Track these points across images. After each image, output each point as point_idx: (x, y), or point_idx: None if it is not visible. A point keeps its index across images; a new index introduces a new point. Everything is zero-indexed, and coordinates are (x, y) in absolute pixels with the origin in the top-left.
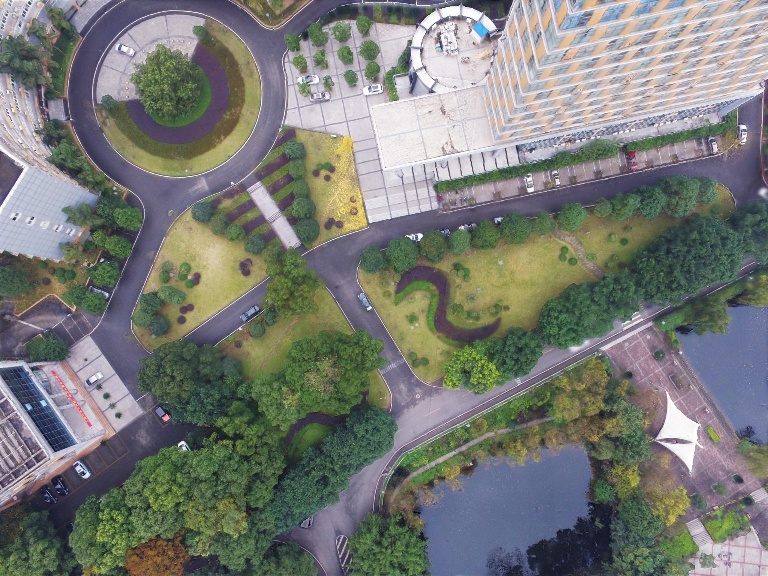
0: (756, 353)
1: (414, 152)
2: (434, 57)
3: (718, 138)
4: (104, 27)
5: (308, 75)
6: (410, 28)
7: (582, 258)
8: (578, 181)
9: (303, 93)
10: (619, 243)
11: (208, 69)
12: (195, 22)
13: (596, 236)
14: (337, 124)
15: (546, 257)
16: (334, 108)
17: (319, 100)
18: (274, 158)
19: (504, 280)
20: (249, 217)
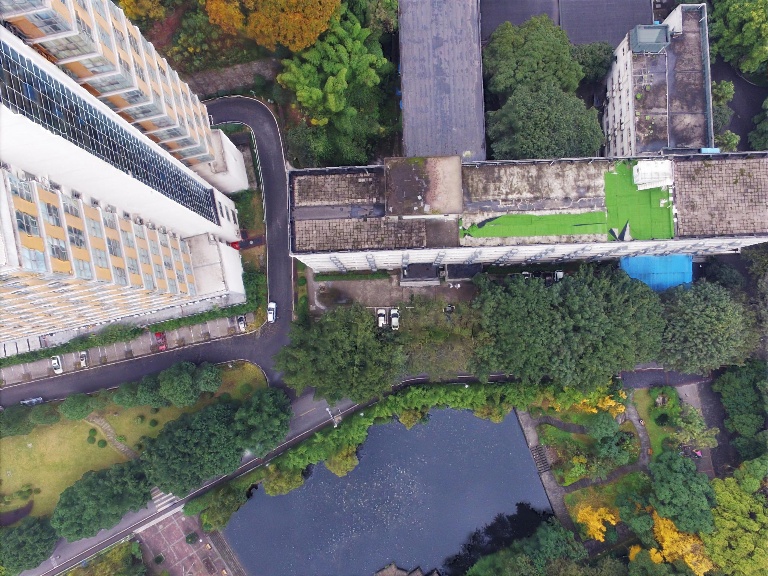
0: (298, 533)
1: None
2: None
3: (251, 315)
4: None
5: None
6: None
7: (112, 440)
8: (108, 361)
9: None
10: (149, 424)
11: None
12: None
13: (126, 417)
14: None
15: (76, 439)
16: None
17: None
18: None
19: (34, 463)
20: None
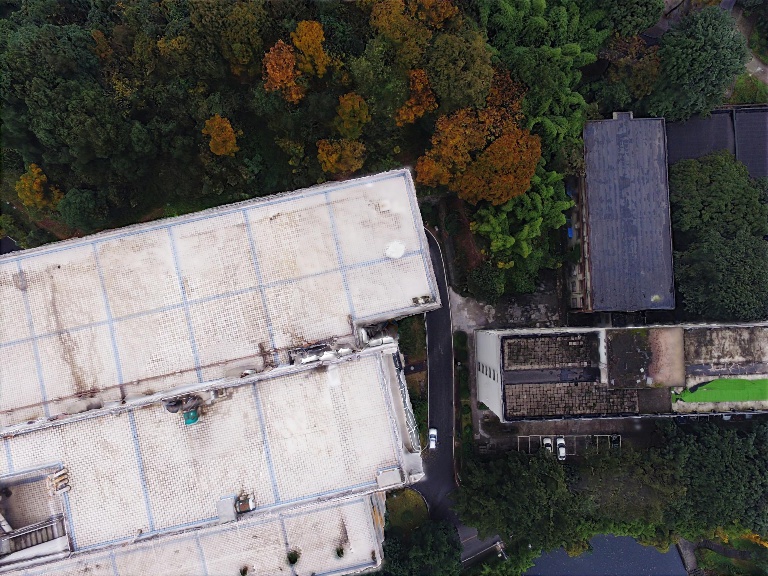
0: None
1: None
2: None
3: None
4: None
5: None
6: None
7: None
8: None
9: None
10: None
11: None
12: None
13: None
14: None
15: None
16: None
17: None
18: None
19: None
20: None
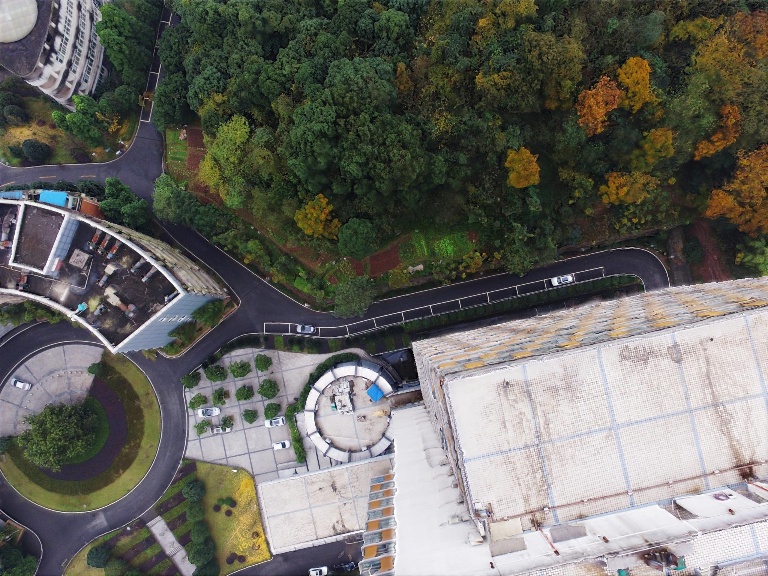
0: None
1: (304, 532)
2: (330, 415)
3: None
4: (0, 358)
5: (208, 408)
6: (313, 357)
7: None
8: None
9: (201, 433)
10: None
11: (106, 403)
12: (93, 352)
13: None
14: (239, 456)
15: None
16: (236, 439)
17: (220, 433)
18: (174, 493)
19: None
20: (149, 553)
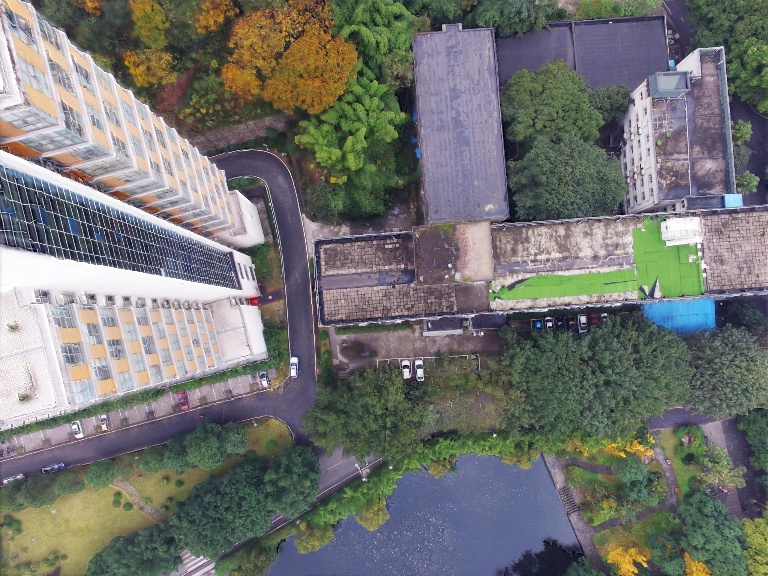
0: None
1: None
2: None
3: (273, 370)
4: None
5: None
6: None
7: (138, 502)
8: (130, 423)
9: None
10: (174, 485)
11: None
12: None
13: (151, 479)
14: None
15: (101, 503)
16: None
17: None
18: None
19: (59, 529)
20: None
